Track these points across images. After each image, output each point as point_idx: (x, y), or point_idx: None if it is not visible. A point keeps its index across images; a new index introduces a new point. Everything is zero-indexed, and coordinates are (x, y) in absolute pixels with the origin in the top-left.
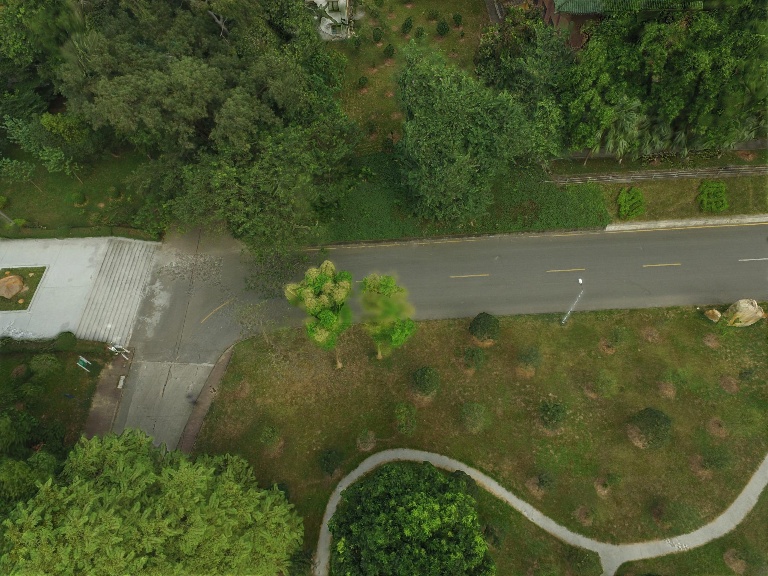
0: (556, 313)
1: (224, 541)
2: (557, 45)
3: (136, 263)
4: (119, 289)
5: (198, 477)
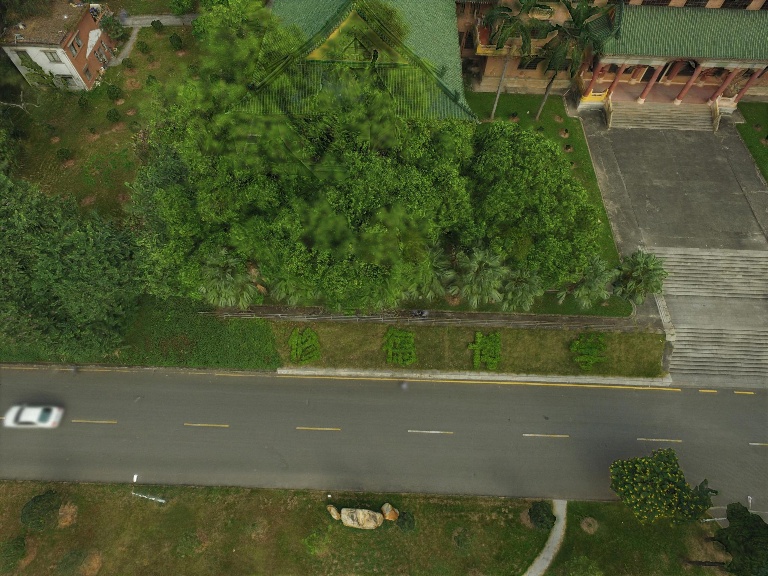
0: (165, 486)
1: None
2: (179, 168)
3: None
4: None
5: None
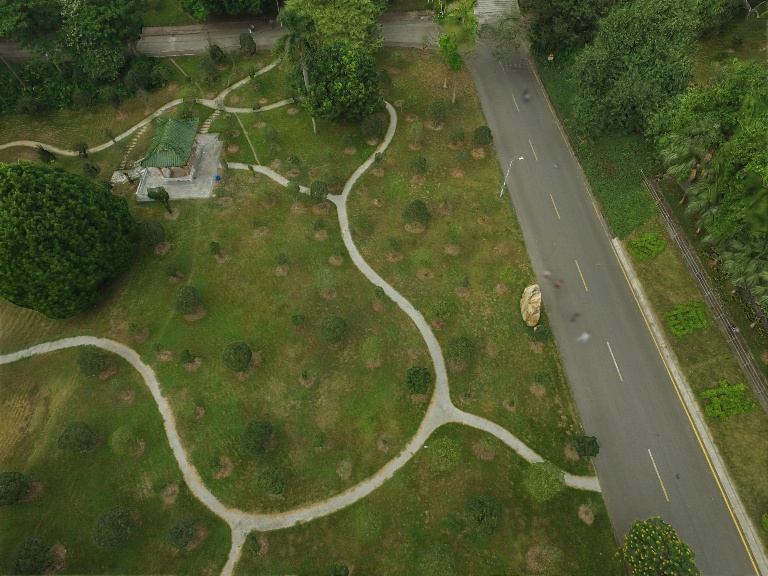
0: (509, 195)
1: (341, 15)
2: None
3: (501, 5)
4: (481, 2)
5: (366, 1)
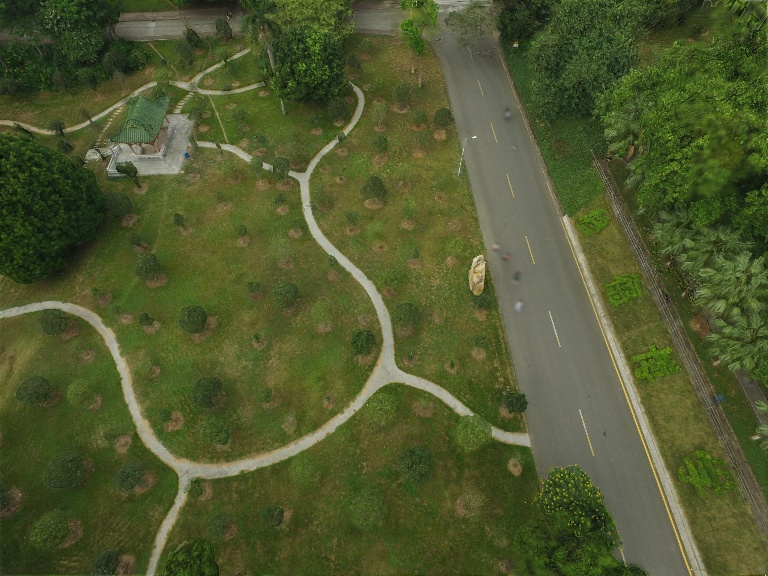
0: (467, 174)
1: (310, 1)
2: None
3: None
4: None
5: None
